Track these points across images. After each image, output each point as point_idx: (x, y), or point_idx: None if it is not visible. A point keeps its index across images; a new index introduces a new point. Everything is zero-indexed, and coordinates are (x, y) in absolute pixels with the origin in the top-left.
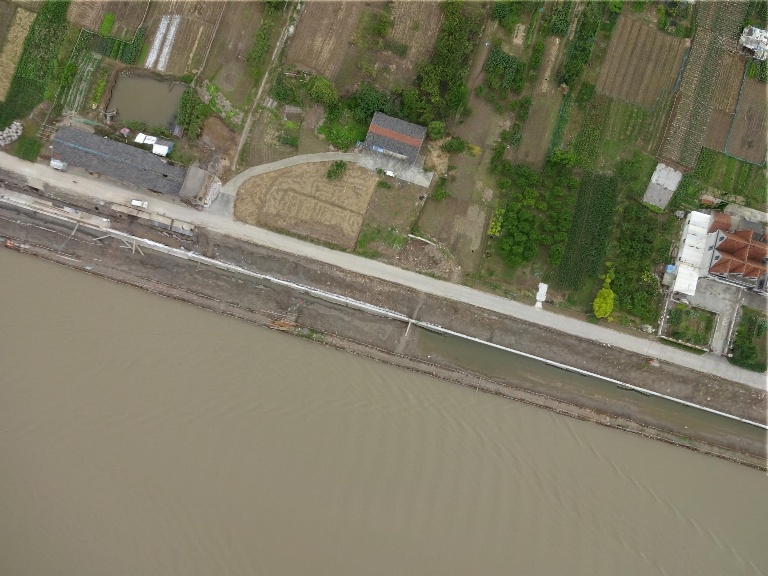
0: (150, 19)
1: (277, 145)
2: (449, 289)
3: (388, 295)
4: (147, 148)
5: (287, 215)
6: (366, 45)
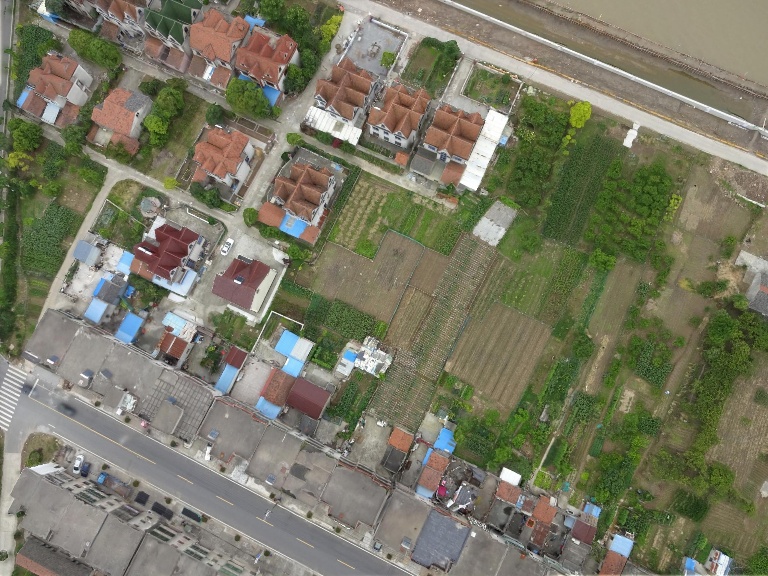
0: None
1: None
2: (724, 152)
3: None
4: None
5: None
6: None
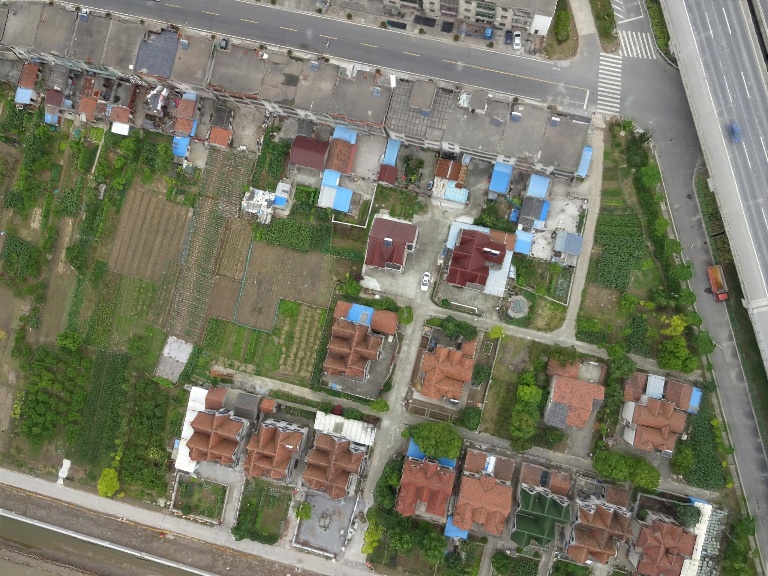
0: None
1: None
2: None
3: None
4: None
5: None
6: None
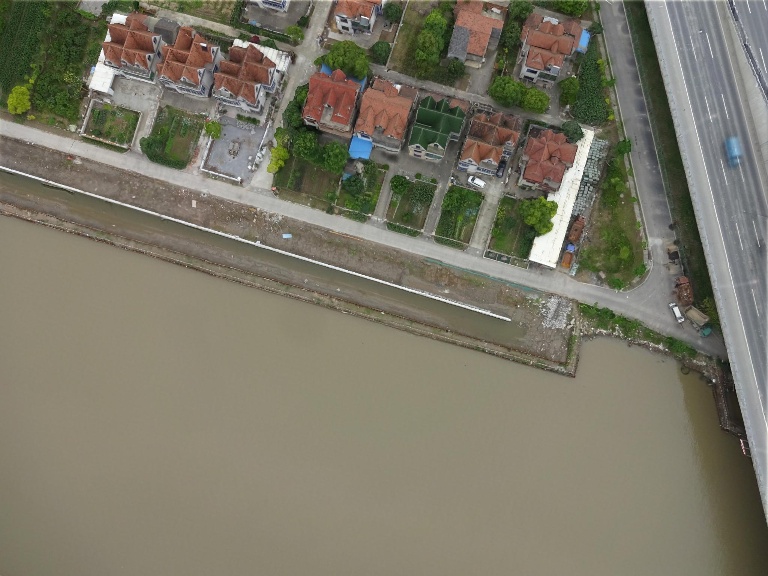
0: None
1: None
2: None
3: None
4: None
5: None
6: None
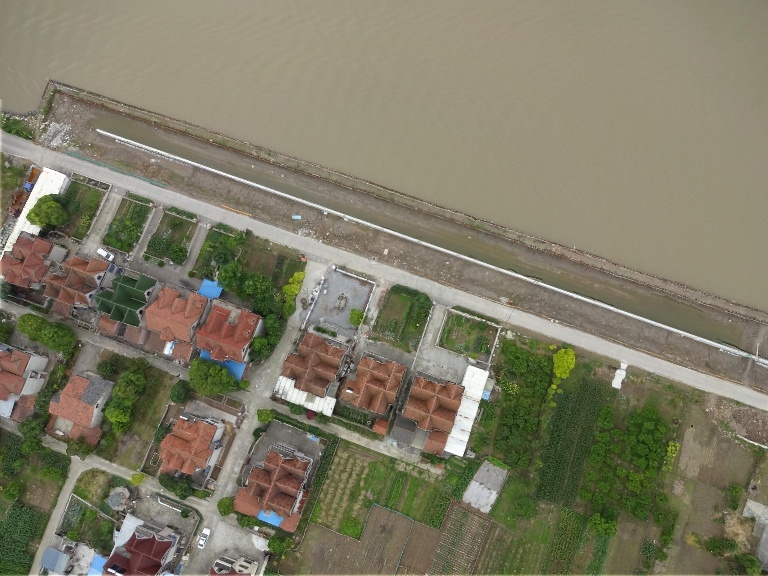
0: None
1: None
2: (719, 388)
3: None
4: None
5: None
6: None
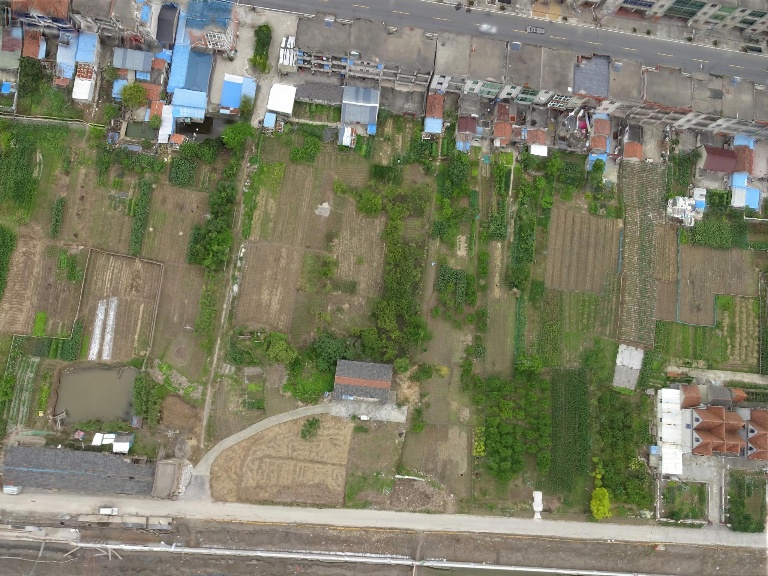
0: (85, 307)
1: (243, 411)
2: (446, 521)
3: (386, 541)
4: (106, 449)
5: (267, 484)
6: (314, 289)
